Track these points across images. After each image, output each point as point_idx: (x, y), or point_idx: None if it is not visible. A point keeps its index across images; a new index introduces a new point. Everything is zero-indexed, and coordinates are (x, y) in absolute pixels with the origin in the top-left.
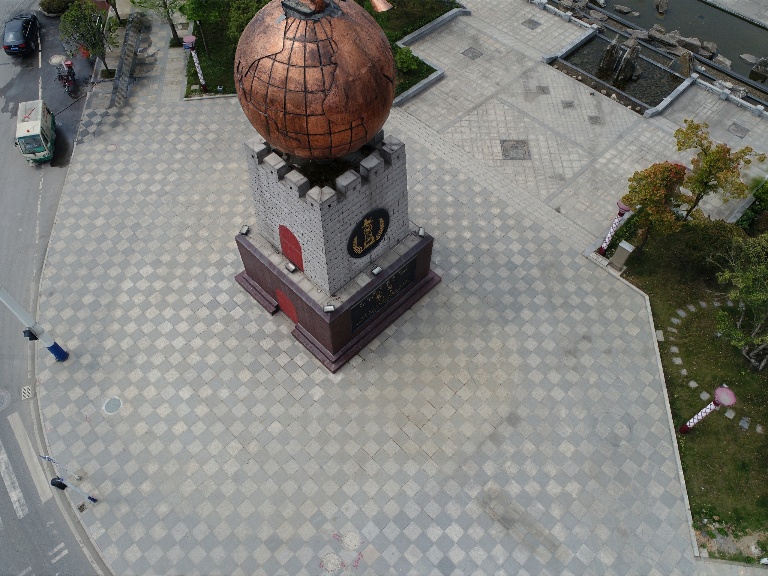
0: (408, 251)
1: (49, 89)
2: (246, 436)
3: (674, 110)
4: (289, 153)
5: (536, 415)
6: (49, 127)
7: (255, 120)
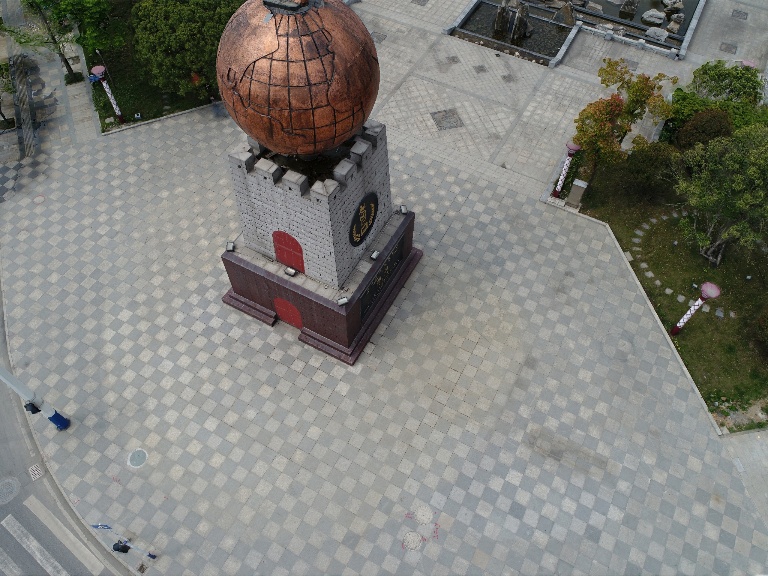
0: (397, 230)
1: None
2: (288, 448)
3: (571, 57)
4: (289, 152)
5: (549, 353)
6: None
7: (255, 125)
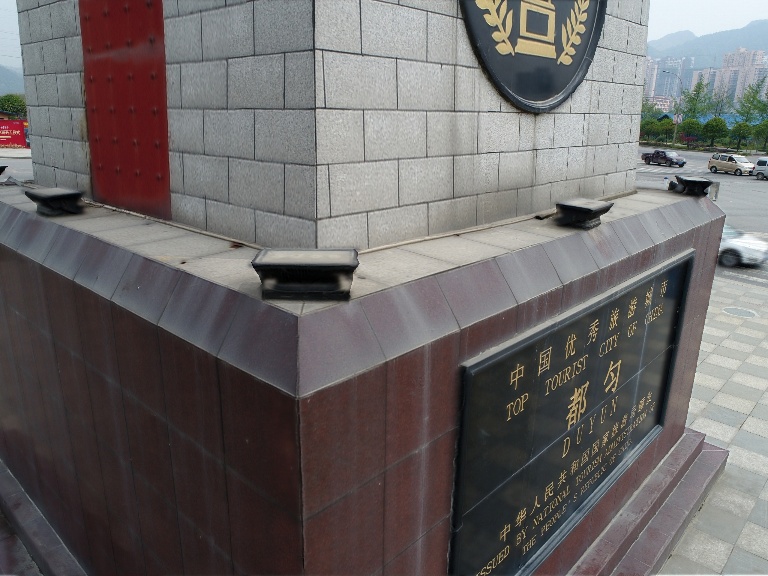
0: None
1: None
2: None
3: None
4: None
5: None
6: None
7: None
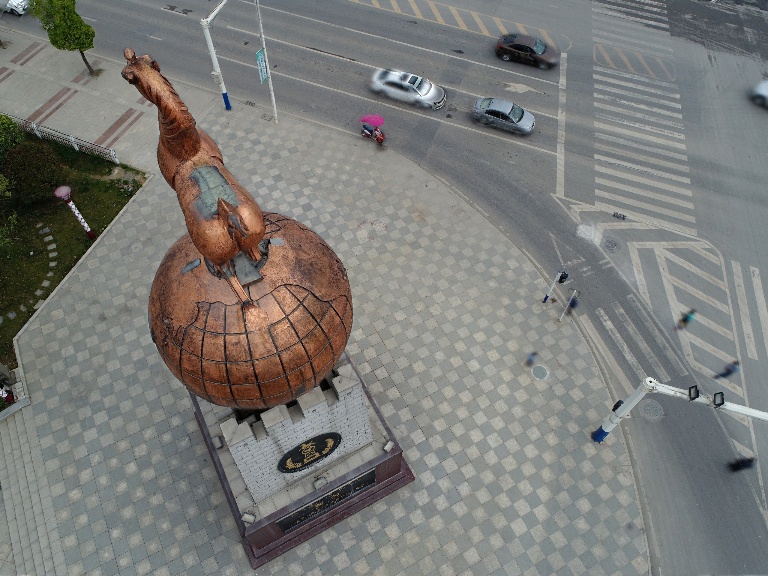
0: None
1: None
2: (425, 316)
3: None
4: None
5: None
6: None
7: None
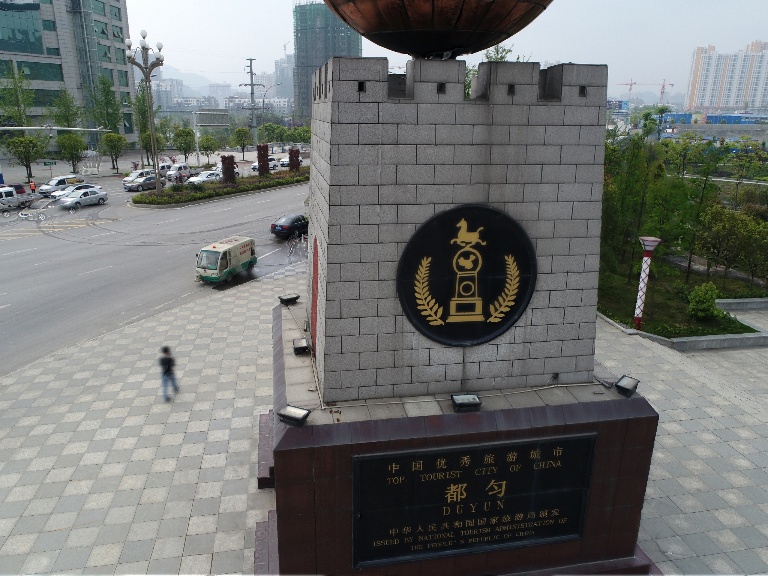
0: (572, 405)
1: (277, 254)
2: None
3: None
4: None
5: None
6: (240, 260)
7: None
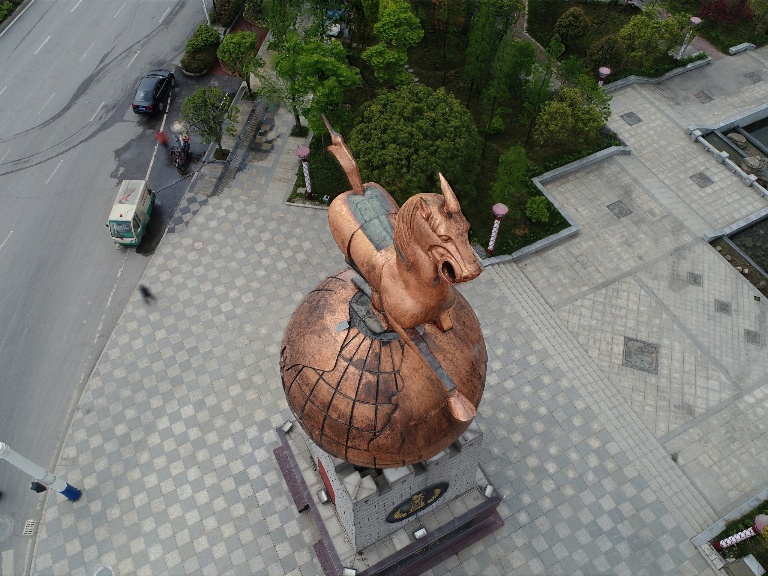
0: (465, 513)
1: (161, 159)
2: None
3: None
4: None
5: None
6: (145, 210)
7: None
